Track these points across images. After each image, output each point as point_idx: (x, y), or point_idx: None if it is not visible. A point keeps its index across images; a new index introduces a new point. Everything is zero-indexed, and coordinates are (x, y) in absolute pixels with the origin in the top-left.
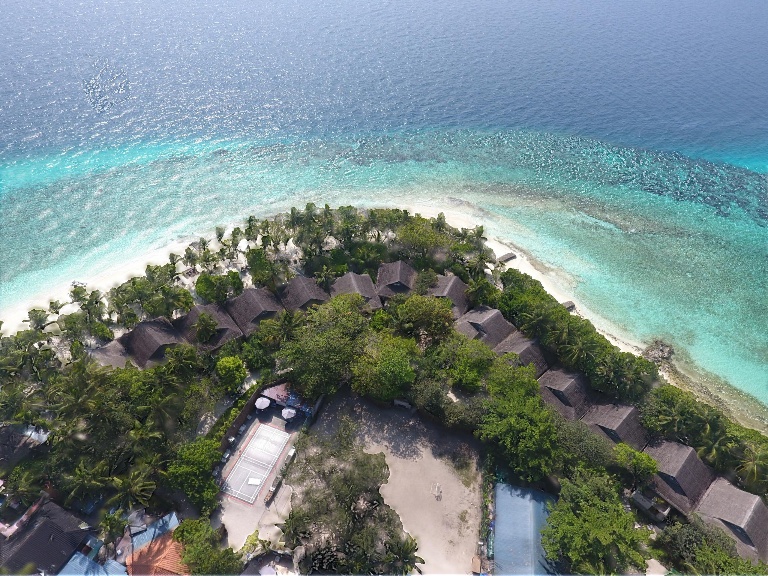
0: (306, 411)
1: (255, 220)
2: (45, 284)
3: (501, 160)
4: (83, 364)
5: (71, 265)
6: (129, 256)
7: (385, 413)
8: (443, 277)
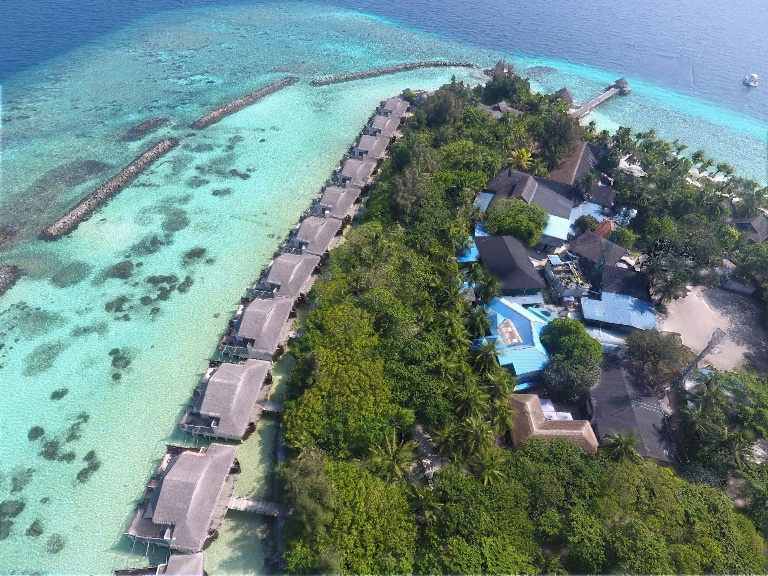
0: (726, 277)
1: None
2: (719, 174)
3: None
4: None
5: None
6: None
7: (759, 327)
8: None
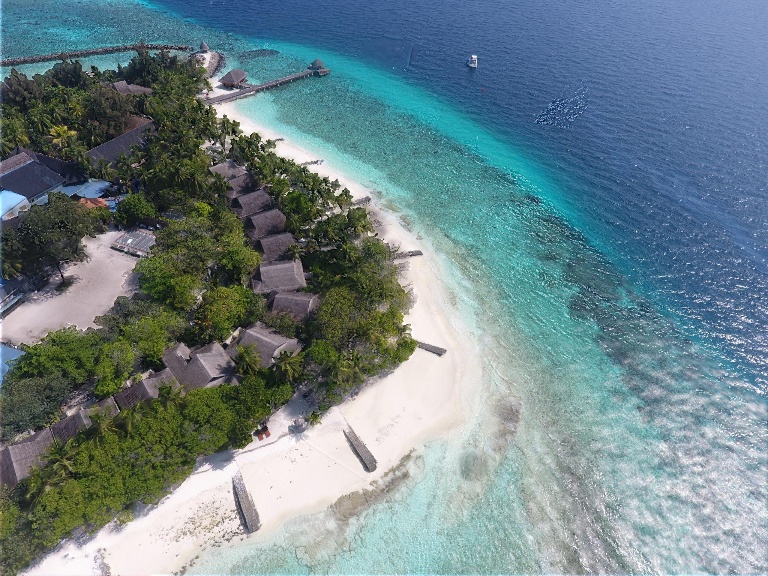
0: None
1: (345, 193)
2: (322, 152)
3: (728, 538)
4: (197, 147)
5: (342, 157)
6: (352, 175)
7: None
8: (286, 340)
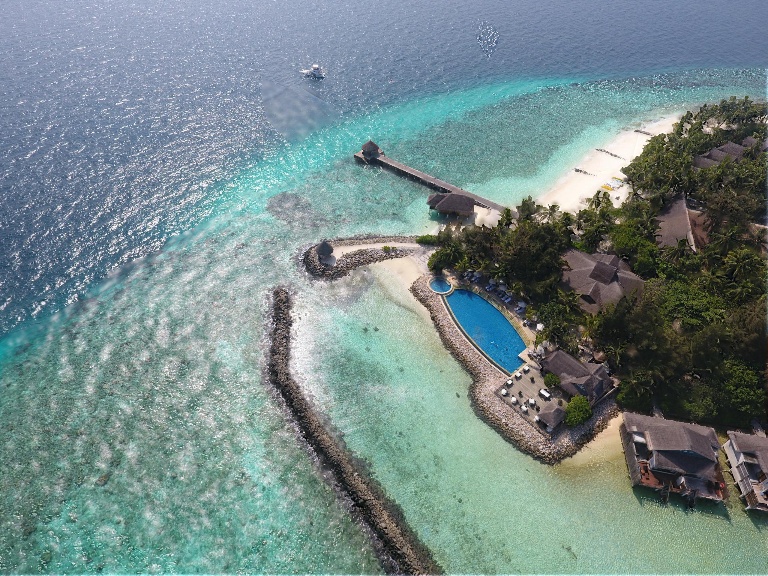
0: None
1: None
2: (581, 150)
3: (763, 85)
4: None
5: (580, 142)
6: None
7: None
8: None
